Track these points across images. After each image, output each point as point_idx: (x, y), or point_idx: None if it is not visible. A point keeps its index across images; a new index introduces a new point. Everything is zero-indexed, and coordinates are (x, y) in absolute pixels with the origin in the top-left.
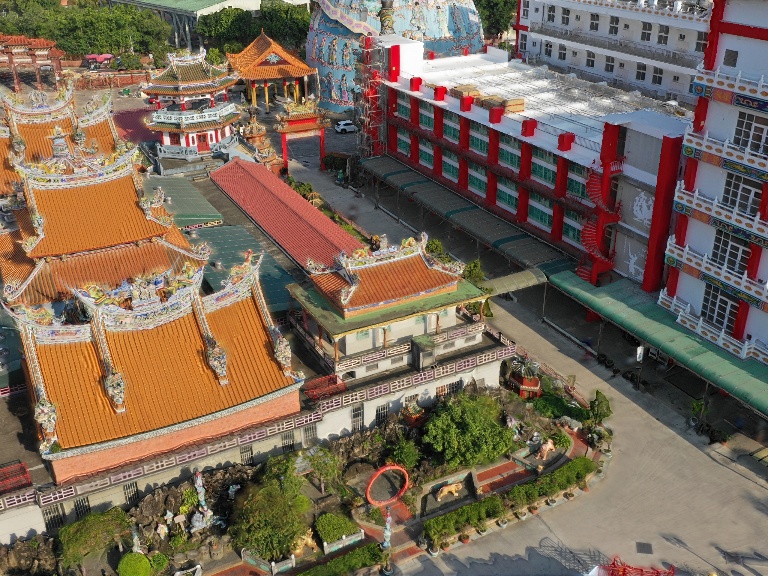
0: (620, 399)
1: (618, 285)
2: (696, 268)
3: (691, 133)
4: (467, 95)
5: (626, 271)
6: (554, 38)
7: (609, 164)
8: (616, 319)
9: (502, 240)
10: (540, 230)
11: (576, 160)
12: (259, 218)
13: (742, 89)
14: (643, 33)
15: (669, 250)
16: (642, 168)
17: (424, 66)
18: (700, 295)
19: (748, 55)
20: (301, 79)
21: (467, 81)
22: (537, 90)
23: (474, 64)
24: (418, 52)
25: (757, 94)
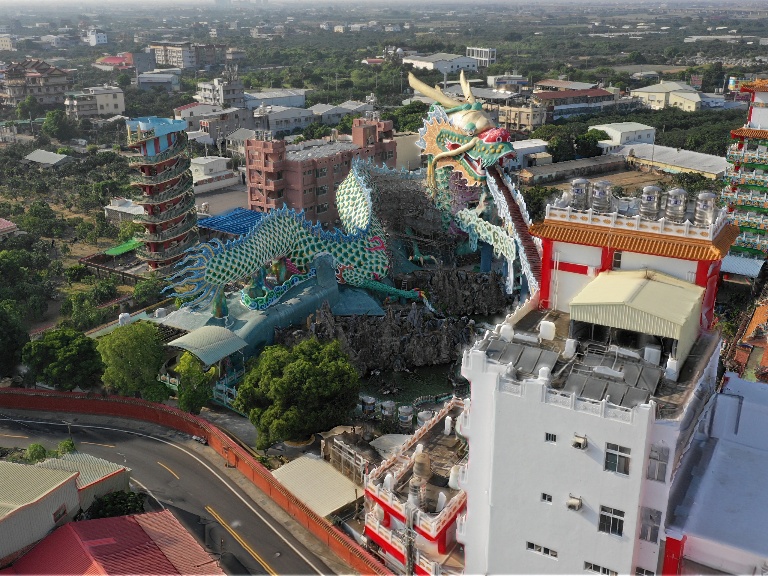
0: None
1: None
2: None
3: None
4: None
5: None
6: None
7: None
8: None
9: None
10: None
11: None
12: None
13: None
14: None
15: None
16: None
17: None
18: None
19: None
20: None
21: None
22: None
23: None
24: None
25: None
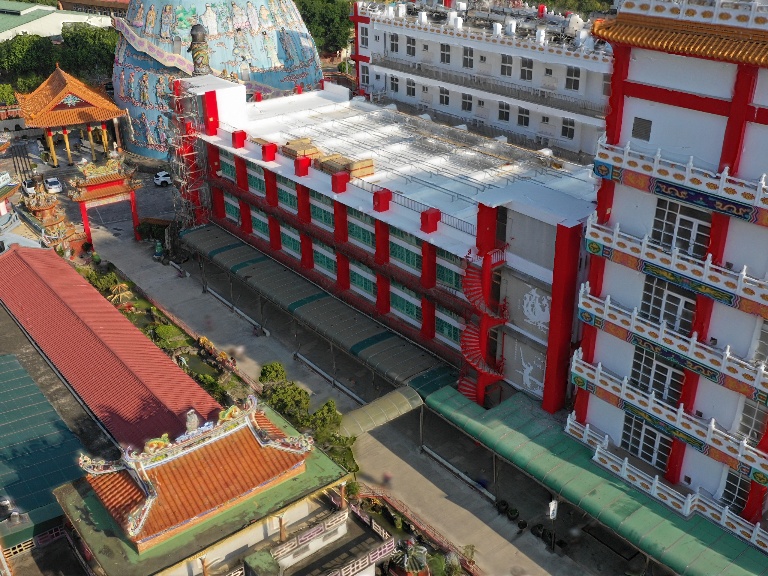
0: (533, 571)
1: (512, 404)
2: (614, 394)
3: (596, 225)
4: (302, 154)
5: (519, 382)
6: (400, 72)
7: (489, 256)
8: (517, 461)
9: (361, 344)
10: (407, 328)
11: (446, 247)
12: (40, 337)
13: (663, 173)
14: (503, 67)
15: (576, 368)
16: (531, 259)
17: (250, 110)
18: (619, 422)
19: (666, 126)
20: (109, 121)
21: (302, 130)
22: (387, 139)
23: (310, 105)
24: (239, 97)
25: (685, 181)
